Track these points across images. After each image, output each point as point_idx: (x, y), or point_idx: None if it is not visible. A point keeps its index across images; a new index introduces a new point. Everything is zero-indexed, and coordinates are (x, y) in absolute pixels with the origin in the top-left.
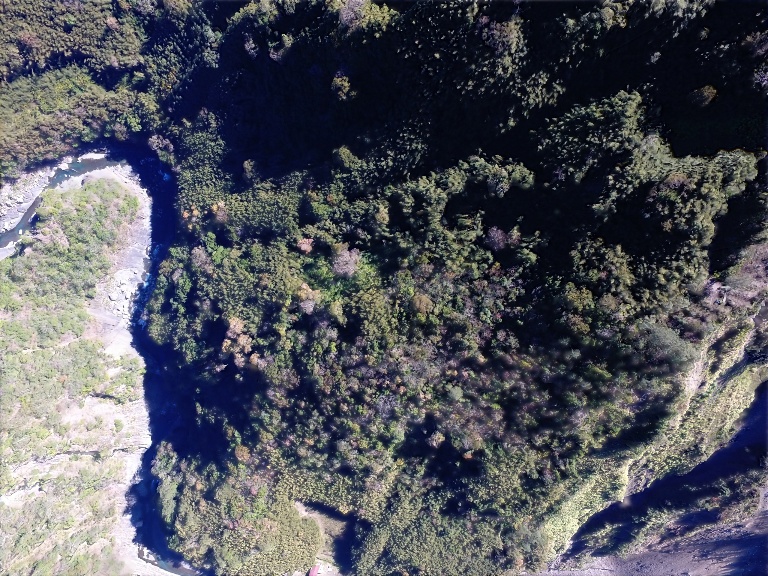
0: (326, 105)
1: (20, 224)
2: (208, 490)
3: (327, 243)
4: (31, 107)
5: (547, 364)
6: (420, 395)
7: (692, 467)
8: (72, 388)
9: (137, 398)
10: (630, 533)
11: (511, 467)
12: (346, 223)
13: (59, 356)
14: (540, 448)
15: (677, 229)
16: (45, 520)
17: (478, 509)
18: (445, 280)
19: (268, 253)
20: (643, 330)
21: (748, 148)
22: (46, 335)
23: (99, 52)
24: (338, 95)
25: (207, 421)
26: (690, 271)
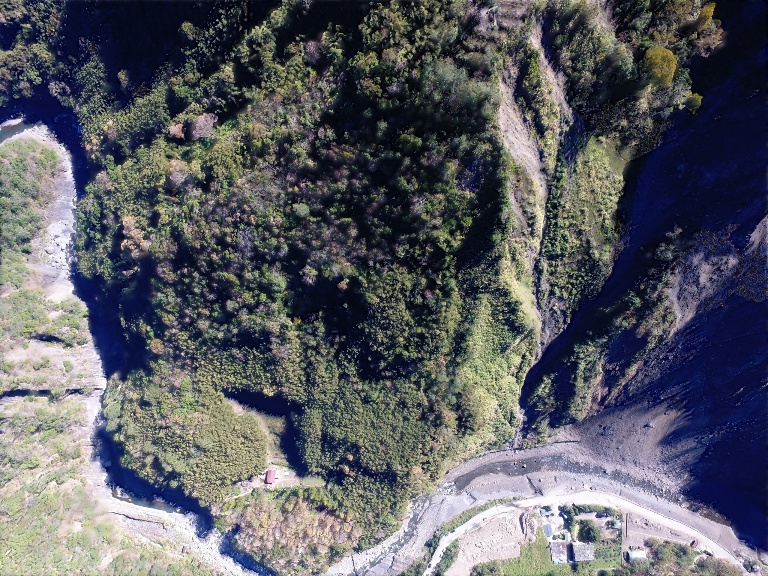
0: None
1: None
2: (142, 397)
3: (194, 123)
4: None
5: (366, 149)
6: (270, 220)
7: (598, 284)
8: (12, 330)
9: (85, 341)
10: (569, 381)
11: (389, 292)
12: None
13: None
14: (411, 265)
15: None
16: (7, 459)
17: (386, 359)
18: (277, 107)
19: (150, 151)
20: (434, 80)
21: None
22: None
23: None
24: None
25: (131, 332)
26: None
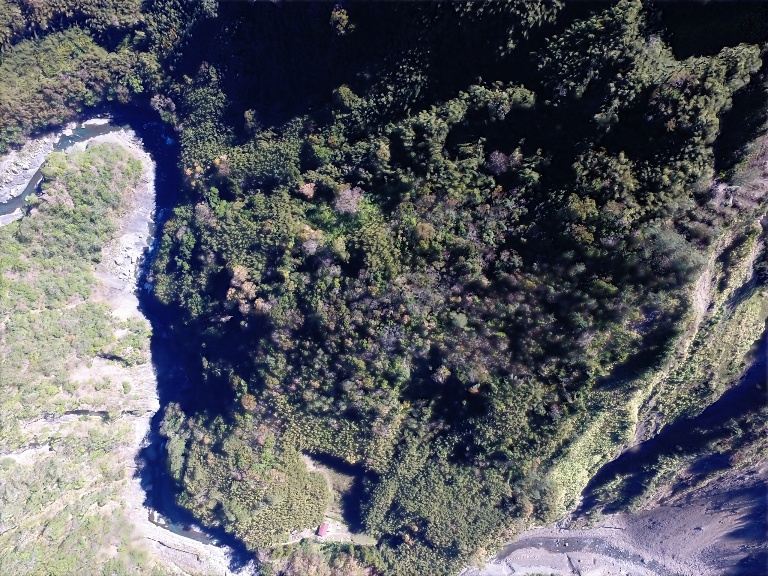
0: (325, 47)
1: (26, 190)
2: (216, 443)
3: (329, 186)
4: (34, 71)
5: (552, 282)
6: (424, 323)
7: (703, 408)
8: (80, 347)
9: (144, 361)
10: (641, 484)
11: (518, 402)
12: (348, 165)
13: (67, 317)
14: (547, 381)
15: (681, 128)
16: (56, 479)
17: (486, 453)
18: (447, 208)
19: (271, 201)
20: (648, 238)
21: (752, 43)
22: (53, 296)
23: (100, 12)
24: (337, 30)
25: (213, 375)
26: (695, 169)
